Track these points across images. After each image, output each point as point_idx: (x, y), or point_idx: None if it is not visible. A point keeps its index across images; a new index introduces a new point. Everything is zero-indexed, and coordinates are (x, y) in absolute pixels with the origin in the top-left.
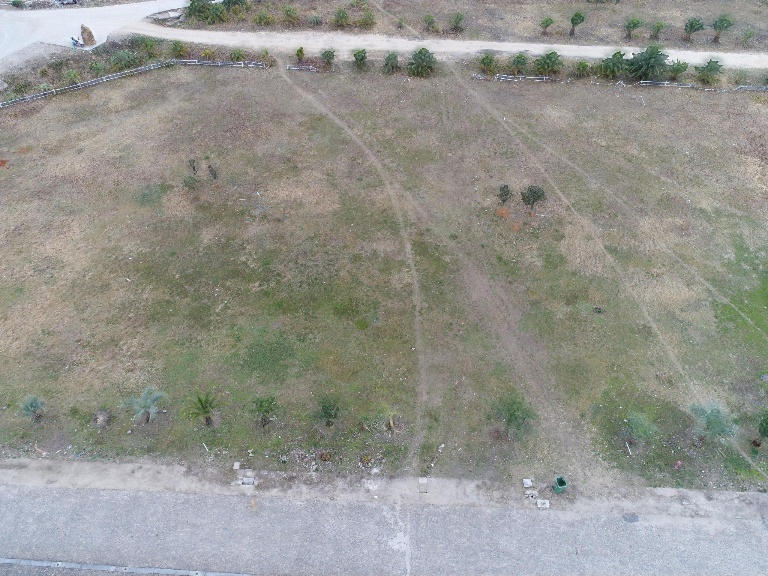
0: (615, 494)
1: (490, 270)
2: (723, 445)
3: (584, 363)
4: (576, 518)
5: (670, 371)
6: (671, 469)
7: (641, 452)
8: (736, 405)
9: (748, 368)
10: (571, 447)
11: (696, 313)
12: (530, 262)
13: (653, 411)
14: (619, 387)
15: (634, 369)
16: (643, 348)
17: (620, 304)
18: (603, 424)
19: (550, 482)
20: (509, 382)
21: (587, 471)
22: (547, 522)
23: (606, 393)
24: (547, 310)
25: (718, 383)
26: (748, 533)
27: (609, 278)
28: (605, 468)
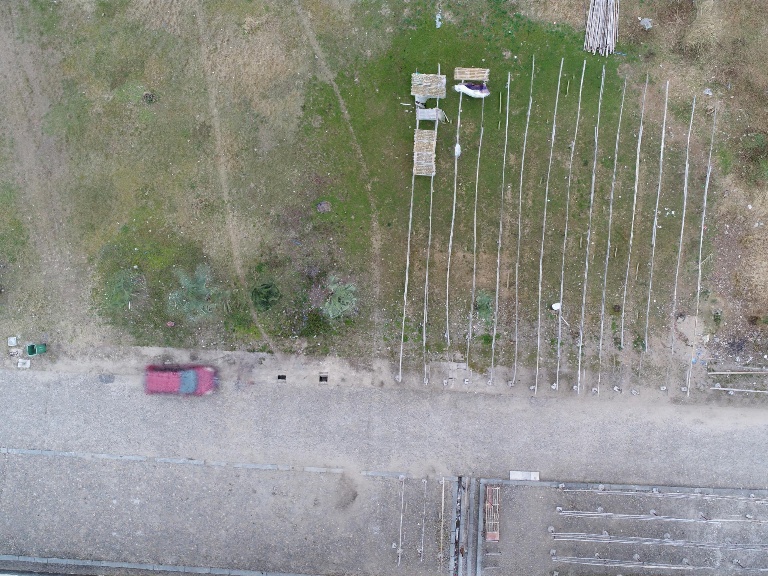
0: (98, 354)
1: (19, 21)
2: (233, 297)
3: (110, 185)
4: (53, 379)
5: (211, 197)
6: (166, 326)
7: (141, 306)
8: (270, 246)
9: (308, 192)
10: (68, 299)
11: (279, 101)
12: (76, 5)
13: (171, 254)
14: (143, 221)
15: (168, 194)
16: (190, 162)
17: (183, 86)
18: (110, 271)
19: (36, 341)
20: (15, 214)
21: (78, 328)
22: (24, 383)
23: (124, 230)
24: (83, 98)
25: (263, 214)
26: (217, 394)
27: (181, 37)
28: (98, 324)
